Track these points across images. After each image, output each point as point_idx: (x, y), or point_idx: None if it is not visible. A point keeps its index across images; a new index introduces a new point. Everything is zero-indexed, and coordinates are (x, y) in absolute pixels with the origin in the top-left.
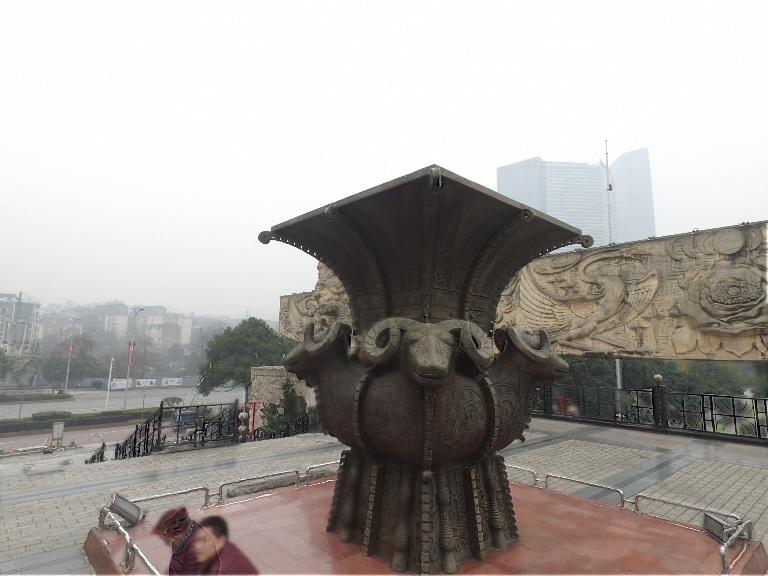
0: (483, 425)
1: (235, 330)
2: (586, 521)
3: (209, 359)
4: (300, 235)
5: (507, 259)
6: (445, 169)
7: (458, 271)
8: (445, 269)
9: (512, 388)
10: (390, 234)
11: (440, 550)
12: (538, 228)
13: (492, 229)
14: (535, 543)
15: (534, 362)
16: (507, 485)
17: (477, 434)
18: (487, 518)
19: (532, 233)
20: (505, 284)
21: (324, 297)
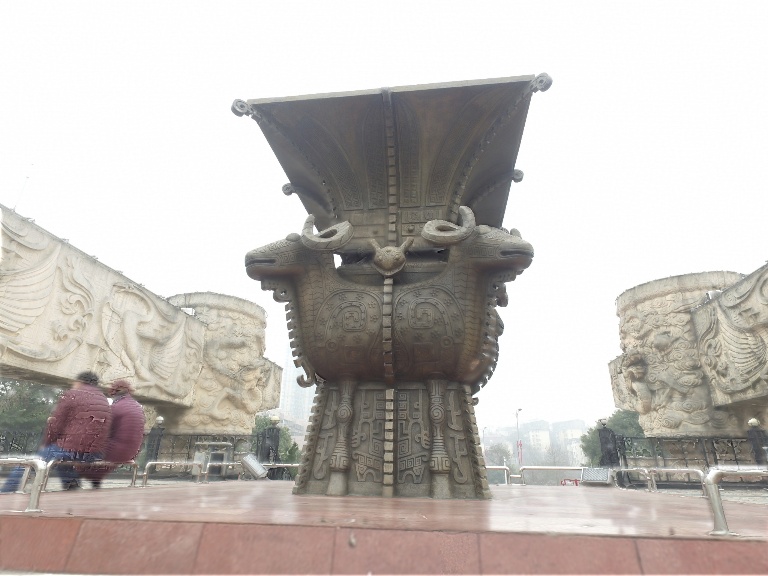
0: (377, 329)
1: (609, 422)
2: (659, 506)
3: (588, 456)
4: (324, 226)
5: (443, 155)
6: (260, 99)
7: (372, 187)
8: (353, 189)
9: (442, 289)
10: (317, 183)
11: (329, 470)
12: (446, 103)
13: (380, 130)
14: (491, 501)
15: (470, 252)
16: (471, 423)
17: (369, 339)
18: (426, 458)
19: (447, 112)
20: (461, 184)
21: (628, 346)
